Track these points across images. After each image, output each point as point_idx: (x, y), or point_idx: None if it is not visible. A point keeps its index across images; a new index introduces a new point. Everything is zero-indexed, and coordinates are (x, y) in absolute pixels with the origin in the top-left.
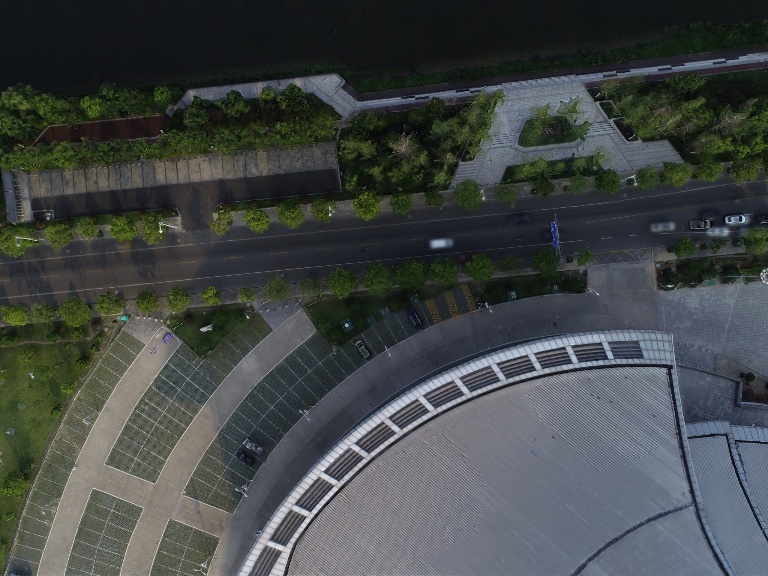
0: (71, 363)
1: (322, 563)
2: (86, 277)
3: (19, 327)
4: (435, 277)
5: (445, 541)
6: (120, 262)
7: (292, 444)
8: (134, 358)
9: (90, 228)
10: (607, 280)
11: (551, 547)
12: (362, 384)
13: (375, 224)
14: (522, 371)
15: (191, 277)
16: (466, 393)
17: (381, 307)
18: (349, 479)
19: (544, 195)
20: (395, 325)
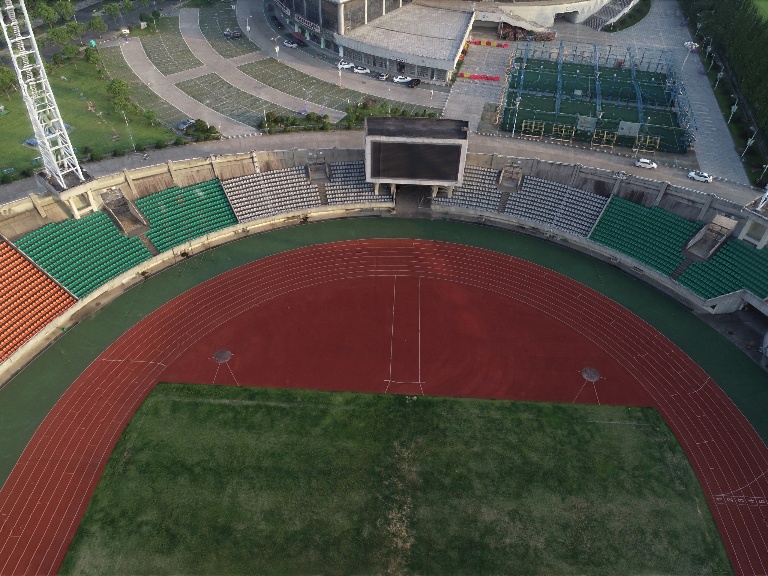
0: None
1: None
2: None
3: None
4: None
5: None
6: None
7: None
8: None
9: None
10: None
11: None
12: None
13: None
14: None
15: None
16: None
17: None
18: None
19: None
20: None
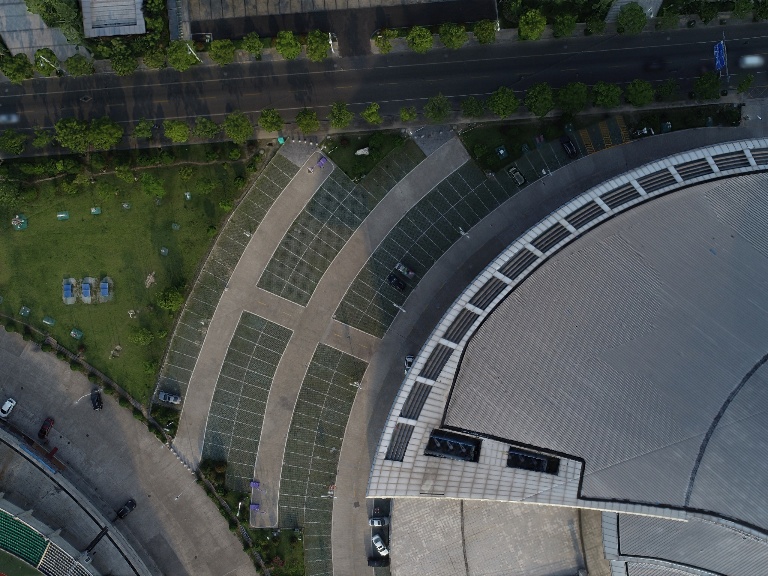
0: (226, 184)
1: (494, 361)
2: (243, 100)
3: (175, 148)
4: (599, 96)
5: (621, 338)
6: (277, 86)
7: (443, 271)
8: (288, 181)
9: (257, 41)
10: (761, 114)
11: (734, 339)
12: (514, 212)
13: (531, 54)
14: (699, 174)
15: (347, 102)
16: (643, 194)
17: (535, 136)
18: (523, 278)
19: (705, 22)
20: (548, 154)
